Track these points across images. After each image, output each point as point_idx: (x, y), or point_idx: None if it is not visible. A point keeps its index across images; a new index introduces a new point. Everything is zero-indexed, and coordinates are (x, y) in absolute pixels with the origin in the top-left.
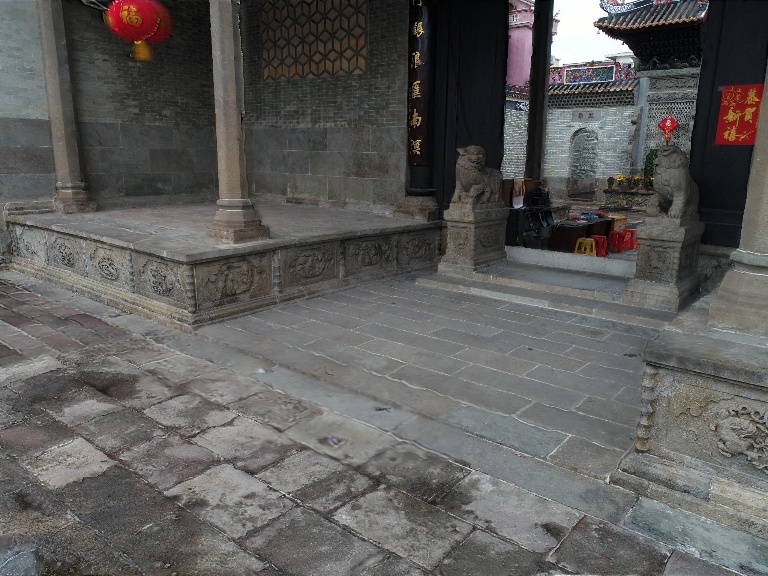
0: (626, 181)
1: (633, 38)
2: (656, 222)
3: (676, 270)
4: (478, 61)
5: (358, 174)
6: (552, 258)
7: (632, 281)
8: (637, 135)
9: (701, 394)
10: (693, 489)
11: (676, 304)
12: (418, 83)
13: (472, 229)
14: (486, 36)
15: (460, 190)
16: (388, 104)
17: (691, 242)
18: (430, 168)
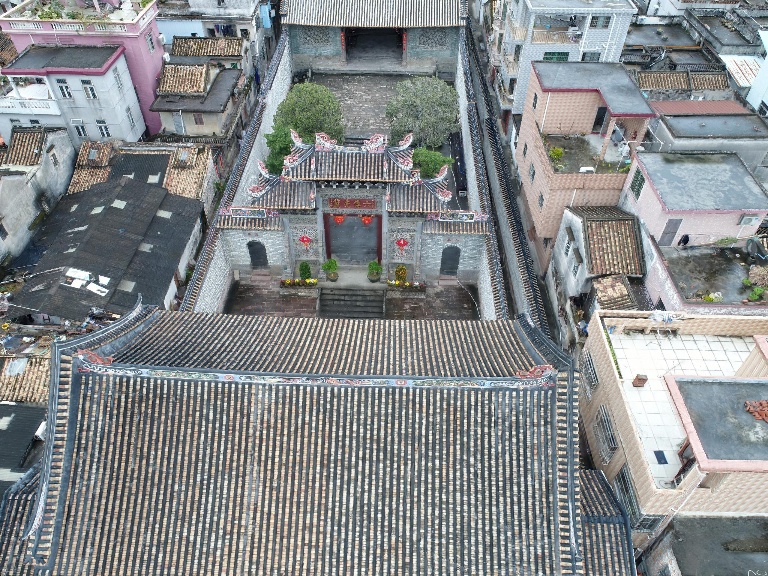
0: (292, 283)
1: None
2: None
3: None
4: None
5: None
6: None
7: None
8: None
9: None
10: None
11: None
12: None
13: None
14: None
15: None
16: None
17: None
18: None
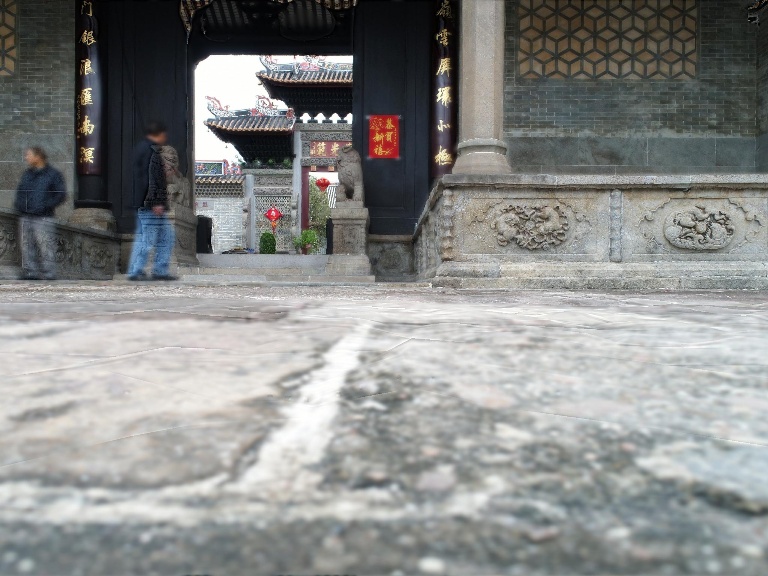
0: None
1: (237, 140)
2: (345, 205)
3: (364, 242)
4: (156, 78)
5: (4, 186)
6: (246, 260)
7: (332, 255)
8: (249, 222)
9: (483, 203)
10: (490, 272)
11: (369, 268)
12: (89, 90)
13: (172, 225)
14: (164, 57)
15: (154, 189)
16: (48, 110)
17: (367, 226)
18: (104, 179)
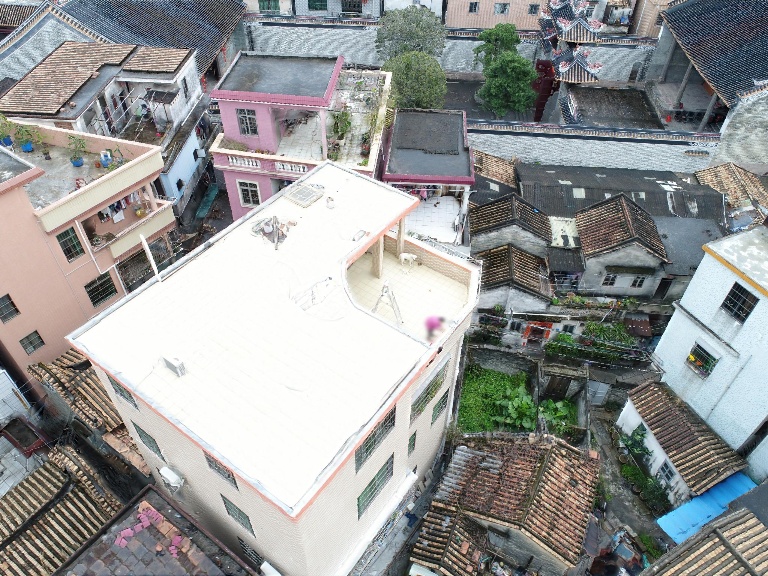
0: None
1: None
2: None
3: None
4: None
5: None
6: None
7: None
8: None
9: None
10: None
11: None
12: None
13: None
14: None
15: None
16: None
17: None
18: None
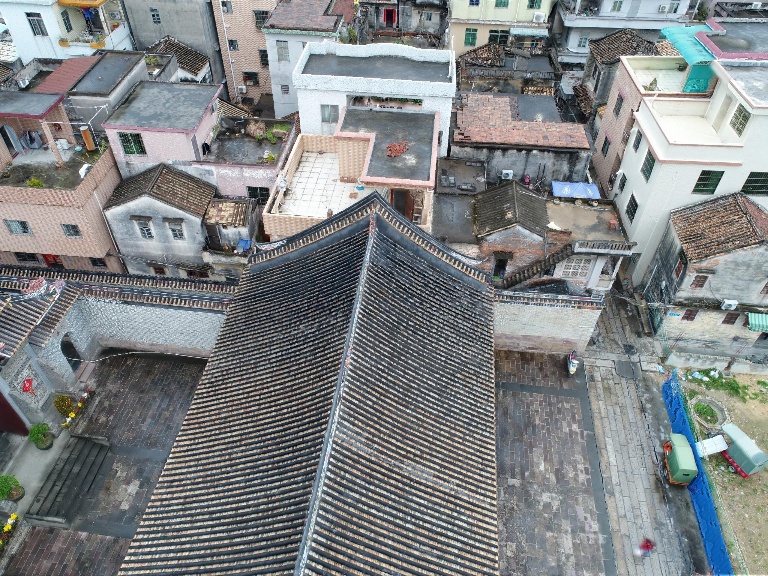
0: None
1: None
2: None
3: None
4: None
5: None
6: None
7: None
8: None
9: None
10: None
11: None
12: None
13: None
14: None
15: None
16: None
17: None
18: None
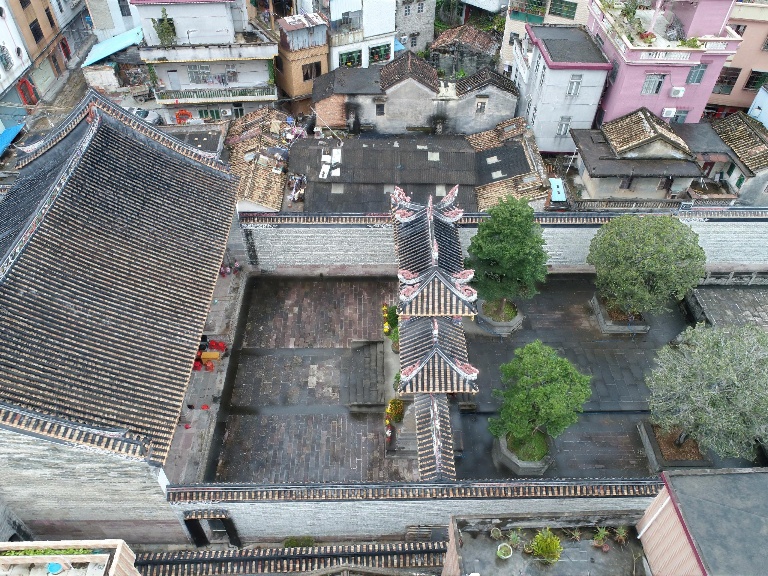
0: None
1: None
2: None
3: None
4: None
5: None
6: None
7: None
8: None
9: None
10: None
11: None
12: None
13: None
14: None
15: None
16: None
17: None
18: None
